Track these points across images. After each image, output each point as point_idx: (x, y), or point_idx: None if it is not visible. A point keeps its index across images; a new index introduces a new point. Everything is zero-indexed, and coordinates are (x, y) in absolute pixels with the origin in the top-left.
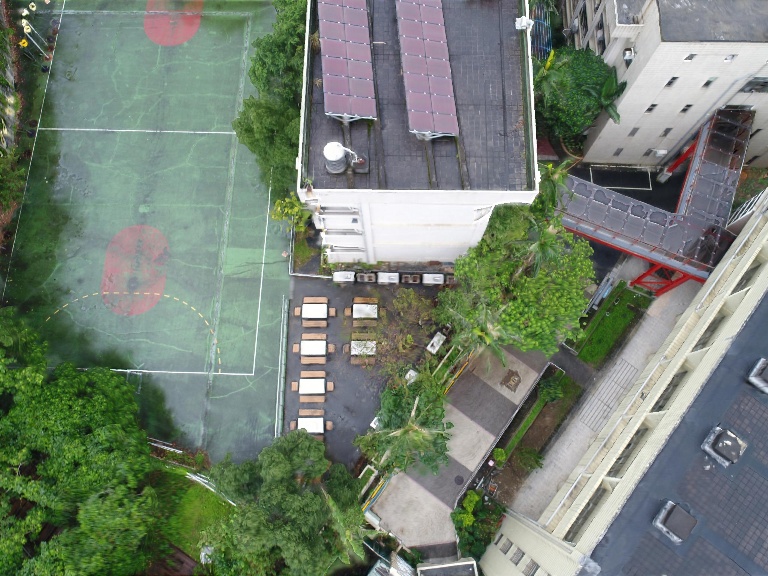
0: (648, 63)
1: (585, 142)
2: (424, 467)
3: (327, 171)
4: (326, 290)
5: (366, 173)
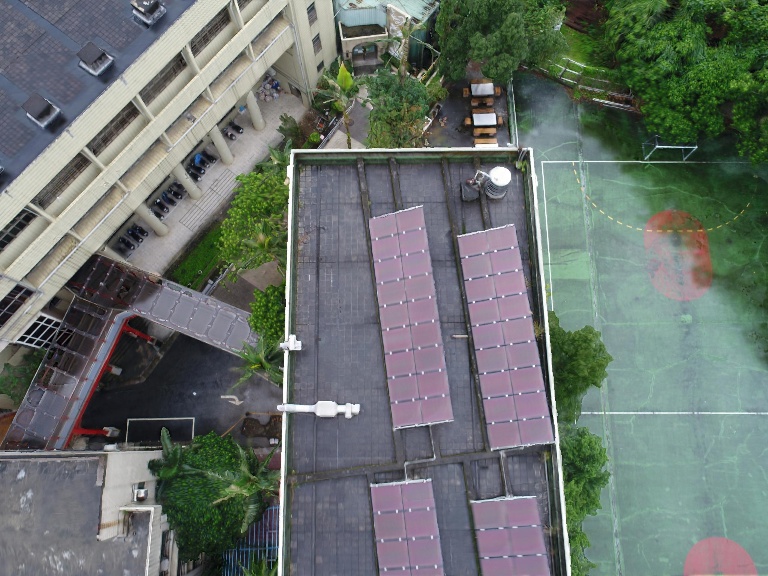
0: (125, 453)
1: None
2: None
3: None
4: None
5: None
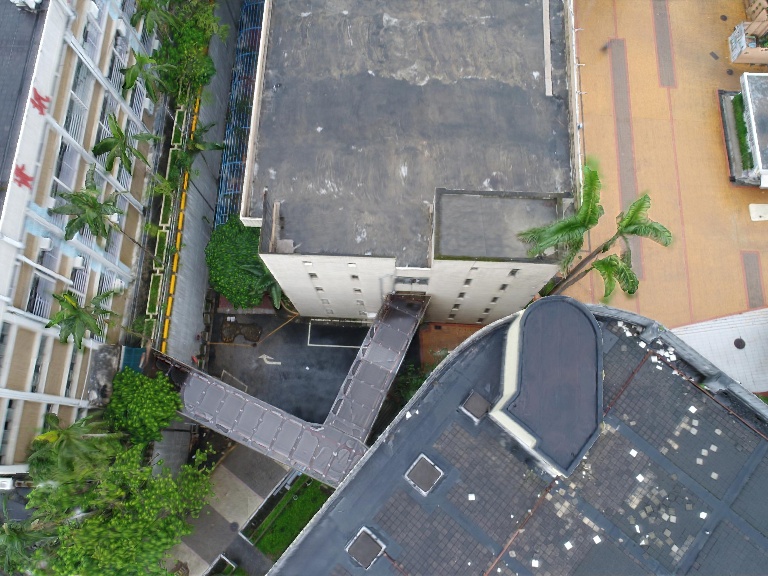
0: (267, 265)
1: None
2: None
3: None
4: None
5: None
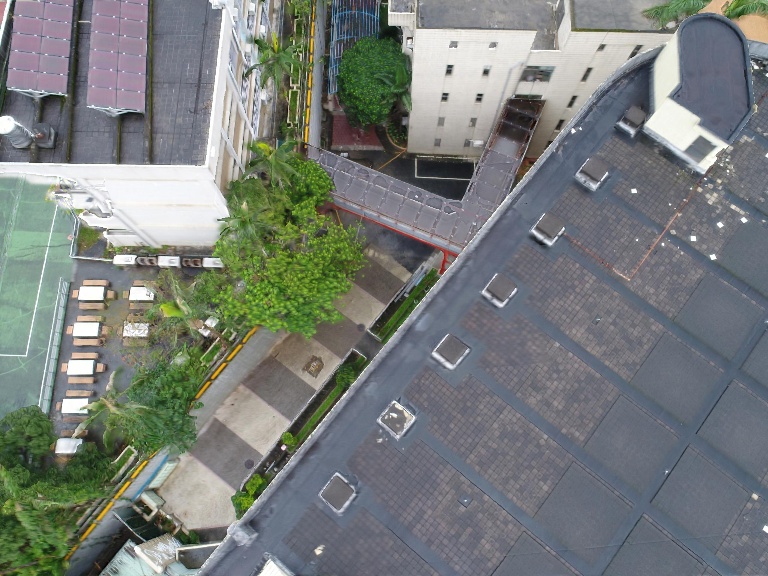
0: (415, 50)
1: (407, 132)
2: (215, 451)
3: (13, 146)
4: (109, 273)
5: (51, 148)
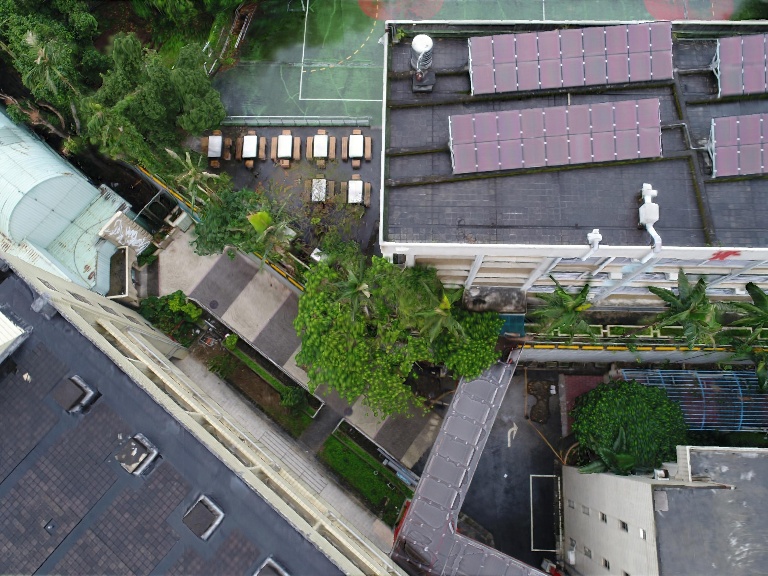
0: (635, 482)
1: None
2: (228, 272)
3: None
4: None
5: None
